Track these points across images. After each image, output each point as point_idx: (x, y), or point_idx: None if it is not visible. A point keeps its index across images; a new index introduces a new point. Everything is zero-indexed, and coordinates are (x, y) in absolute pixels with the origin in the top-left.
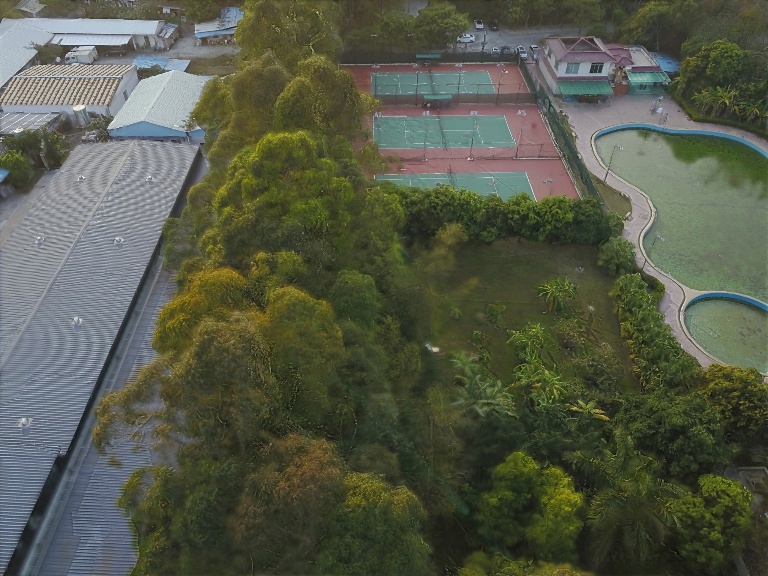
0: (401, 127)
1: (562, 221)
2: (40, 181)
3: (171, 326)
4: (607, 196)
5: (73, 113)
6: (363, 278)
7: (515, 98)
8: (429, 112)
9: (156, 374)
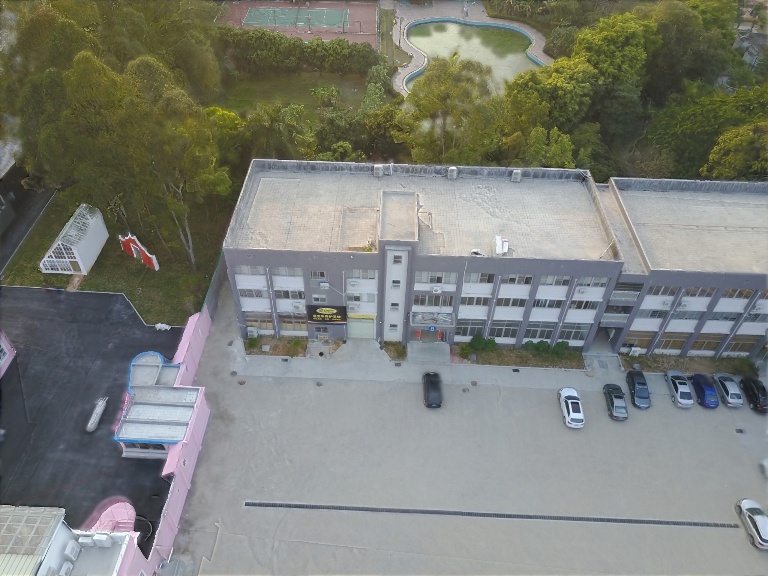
0: (268, 13)
1: (340, 54)
2: None
3: None
4: (397, 55)
5: None
6: (137, 13)
7: None
8: (293, 6)
9: None
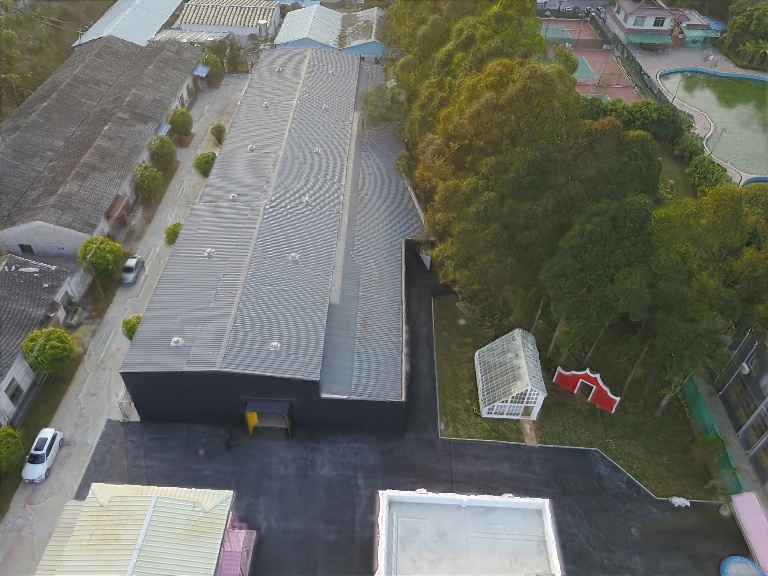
0: None
1: (649, 118)
2: (224, 81)
3: (484, 84)
4: None
5: (238, 34)
6: None
7: (591, 44)
8: None
9: (492, 99)
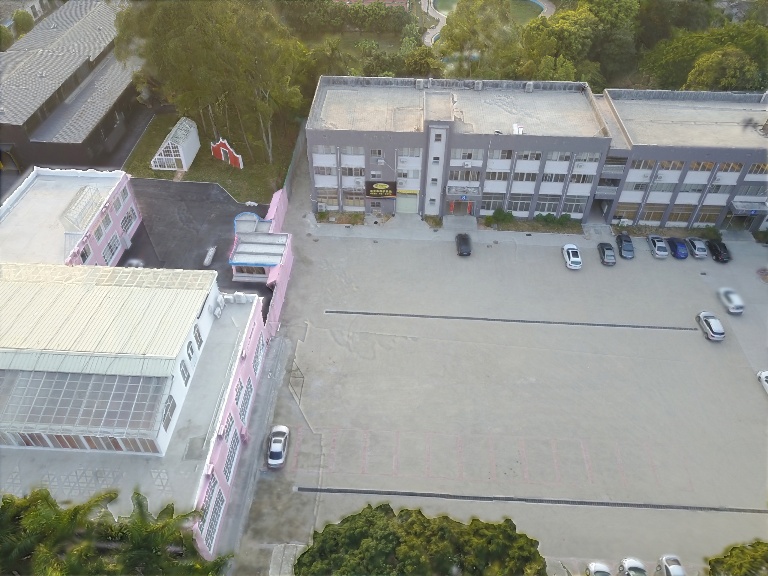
0: None
1: (379, 15)
2: None
3: None
4: None
5: None
6: None
7: None
8: None
9: None
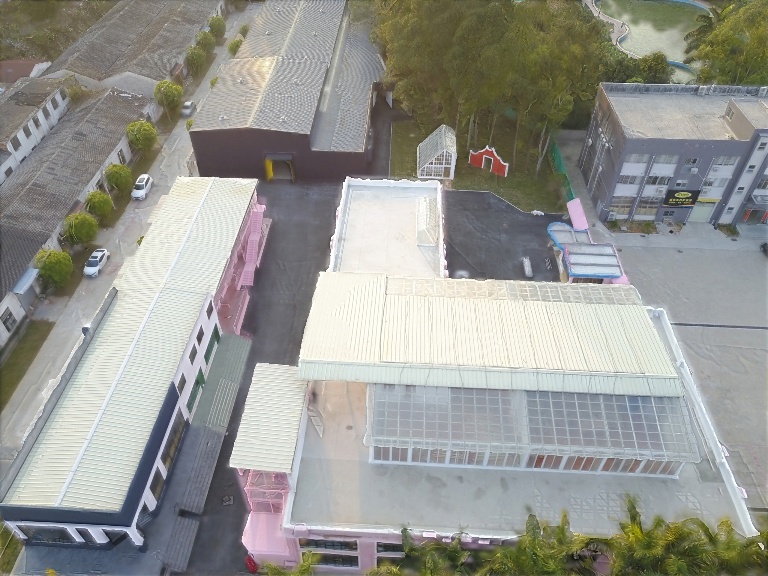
0: None
1: None
2: (248, 7)
3: None
4: None
5: None
6: None
7: None
8: None
9: None
